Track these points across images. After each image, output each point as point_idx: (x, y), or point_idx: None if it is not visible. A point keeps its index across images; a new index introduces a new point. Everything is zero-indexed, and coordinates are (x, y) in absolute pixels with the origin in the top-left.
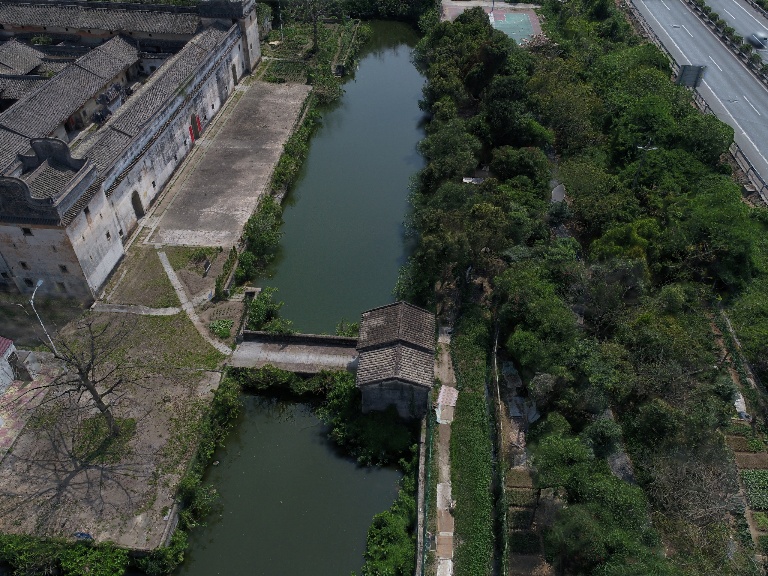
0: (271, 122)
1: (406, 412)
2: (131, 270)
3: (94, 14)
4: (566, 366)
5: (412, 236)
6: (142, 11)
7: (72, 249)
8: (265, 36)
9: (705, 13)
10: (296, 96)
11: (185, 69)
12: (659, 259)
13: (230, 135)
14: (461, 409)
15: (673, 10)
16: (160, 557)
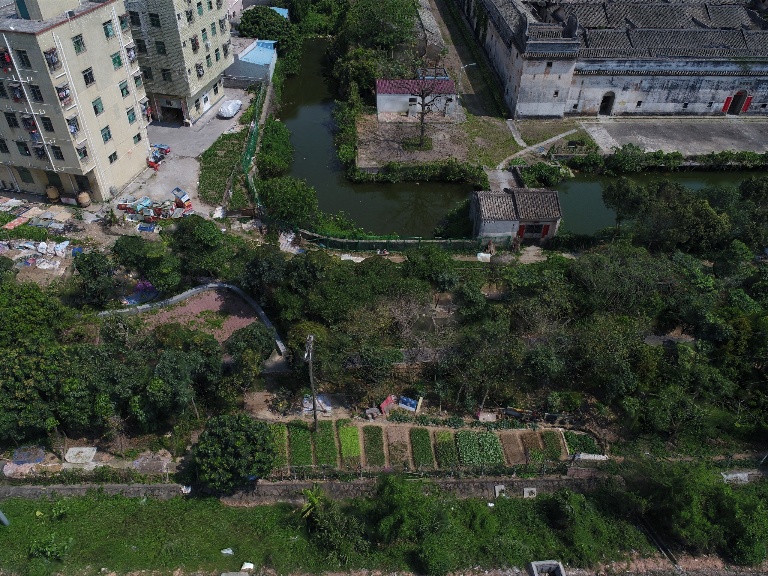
0: None
1: None
2: (550, 124)
3: None
4: None
5: None
6: None
7: (521, 76)
8: None
9: None
10: None
11: None
12: None
13: (763, 128)
14: None
15: None
16: (354, 170)
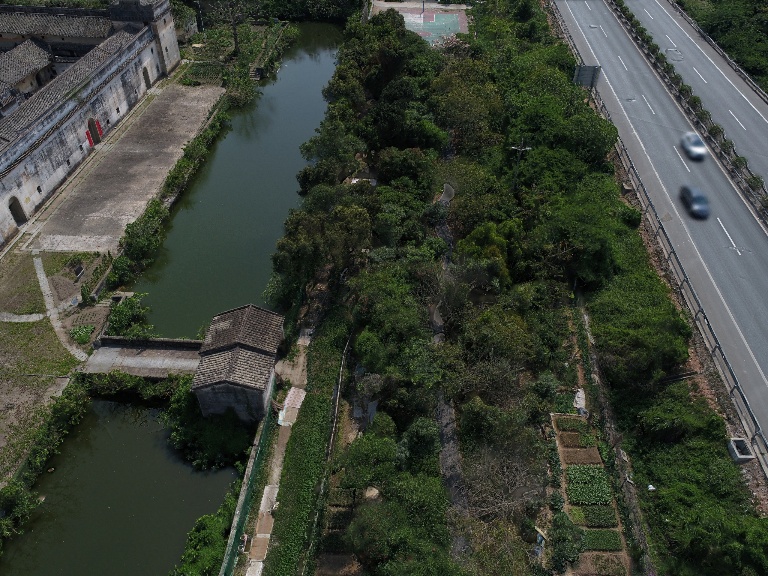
0: (177, 125)
1: (245, 415)
2: (2, 277)
3: (5, 18)
4: (403, 366)
5: None
6: (54, 15)
7: None
8: (189, 39)
9: (623, 13)
10: (208, 99)
11: (84, 73)
12: (523, 258)
13: (133, 139)
14: (304, 411)
15: (594, 10)
16: None
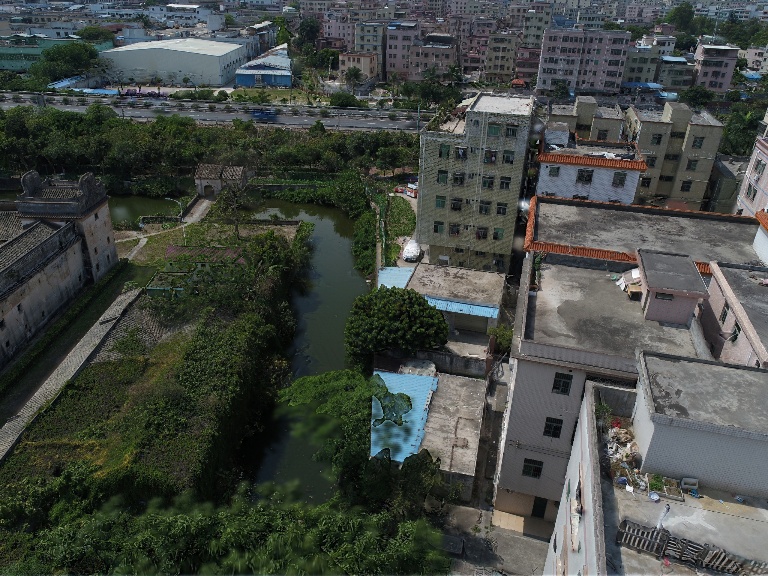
0: None
1: None
2: None
3: None
4: None
5: (109, 190)
6: None
7: None
8: None
9: None
10: None
11: None
12: None
13: None
14: None
15: None
16: None
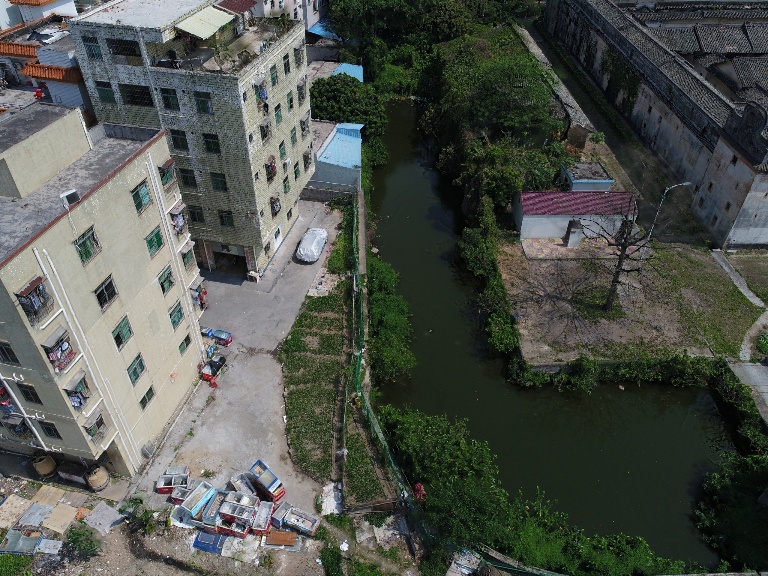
0: None
1: None
2: None
3: None
4: None
5: None
6: None
7: (746, 194)
8: None
9: None
10: None
11: None
12: None
13: None
14: None
15: None
16: (522, 368)
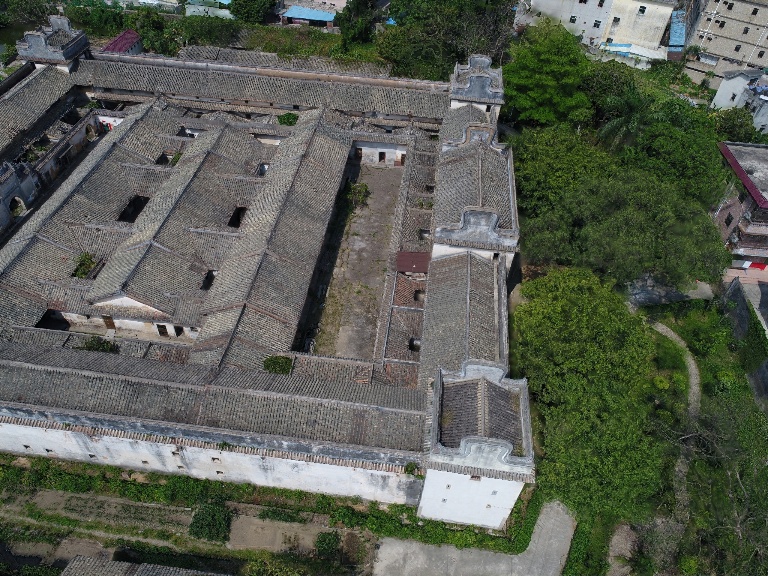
0: None
1: None
2: None
3: None
4: None
5: None
6: None
7: None
8: None
9: None
10: None
11: None
12: None
13: None
14: None
15: None
16: None
